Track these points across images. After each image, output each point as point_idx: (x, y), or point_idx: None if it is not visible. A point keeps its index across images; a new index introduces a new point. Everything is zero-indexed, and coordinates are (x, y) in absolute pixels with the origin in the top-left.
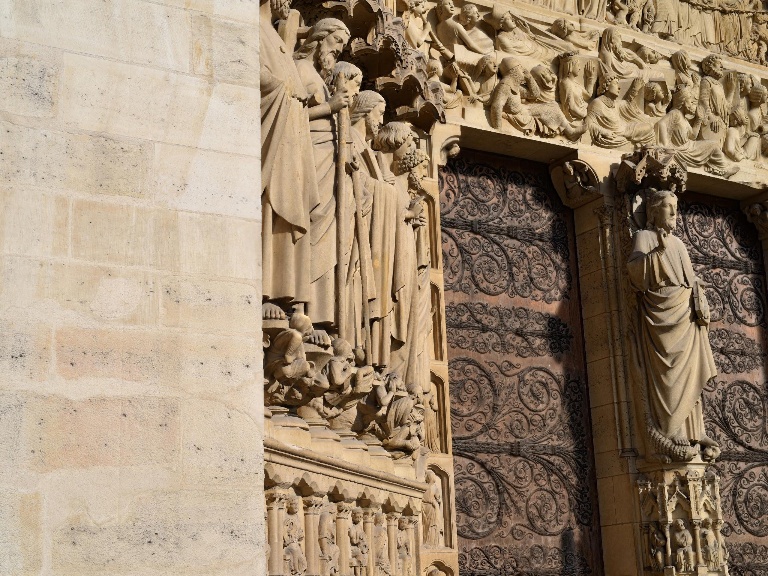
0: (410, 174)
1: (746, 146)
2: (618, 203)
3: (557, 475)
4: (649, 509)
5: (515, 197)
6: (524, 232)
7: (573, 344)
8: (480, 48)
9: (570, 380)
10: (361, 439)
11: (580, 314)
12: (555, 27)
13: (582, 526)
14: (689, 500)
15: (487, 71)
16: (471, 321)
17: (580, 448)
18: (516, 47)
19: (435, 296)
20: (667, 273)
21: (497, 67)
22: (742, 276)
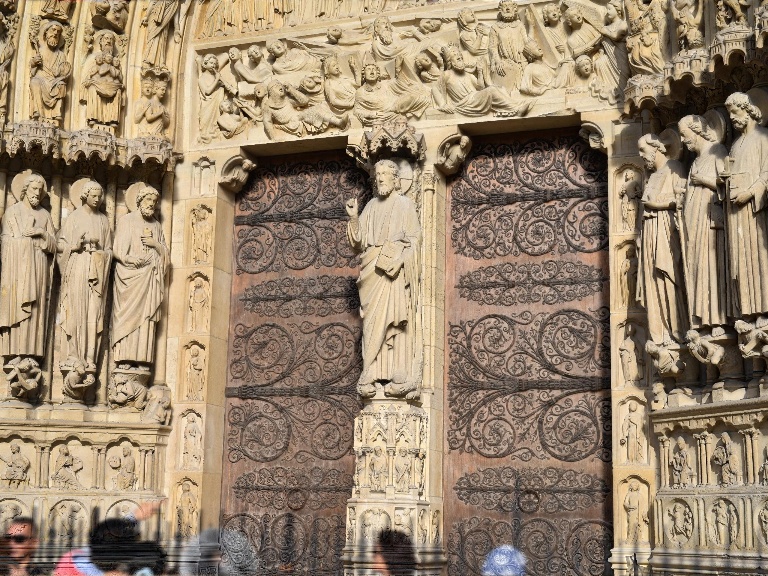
0: None
1: None
2: None
3: (343, 411)
4: None
5: (330, 183)
6: (334, 212)
7: None
8: (258, 79)
9: None
10: None
11: None
12: None
13: None
14: (362, 431)
15: None
16: (279, 293)
17: None
18: (286, 68)
19: None
20: (354, 238)
21: (267, 91)
22: (585, 203)
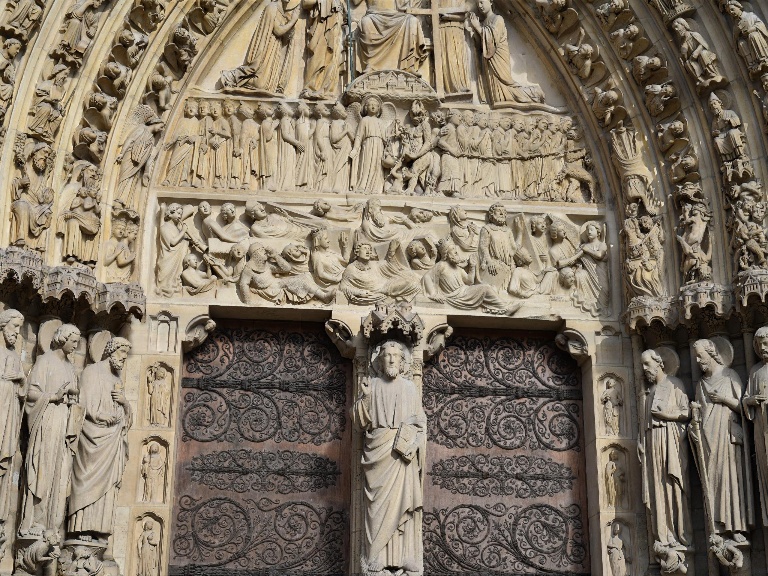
0: (110, 358)
1: (541, 282)
2: None
3: None
4: None
5: (292, 355)
6: (297, 385)
7: (340, 479)
8: (233, 238)
9: (332, 512)
10: (15, 573)
11: None
12: (313, 208)
13: None
14: None
15: (235, 257)
16: (233, 466)
17: (336, 572)
18: (268, 232)
19: (167, 450)
20: (368, 417)
21: (246, 252)
22: (554, 403)
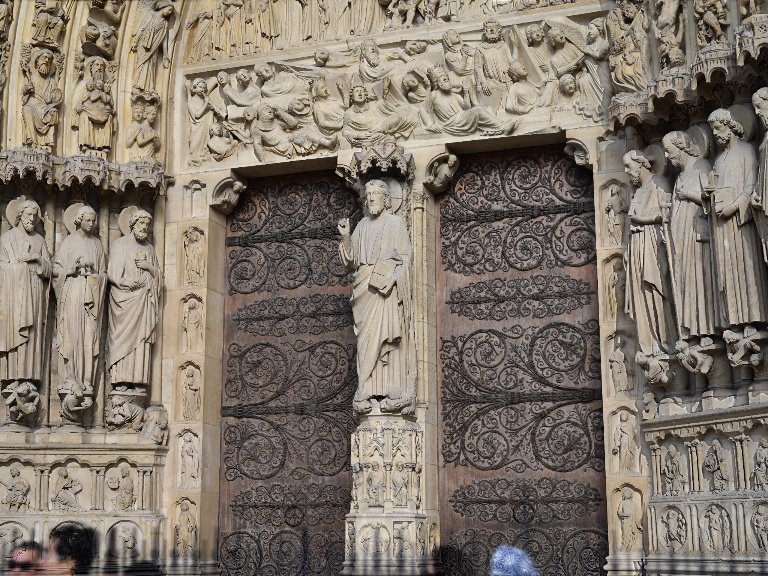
0: (133, 230)
1: None
2: None
3: (338, 427)
4: None
5: (320, 203)
6: (324, 231)
7: None
8: (247, 102)
9: None
10: None
11: None
12: None
13: None
14: (359, 447)
15: None
16: (272, 313)
17: None
18: (275, 91)
19: None
20: (347, 257)
21: None
22: (572, 218)
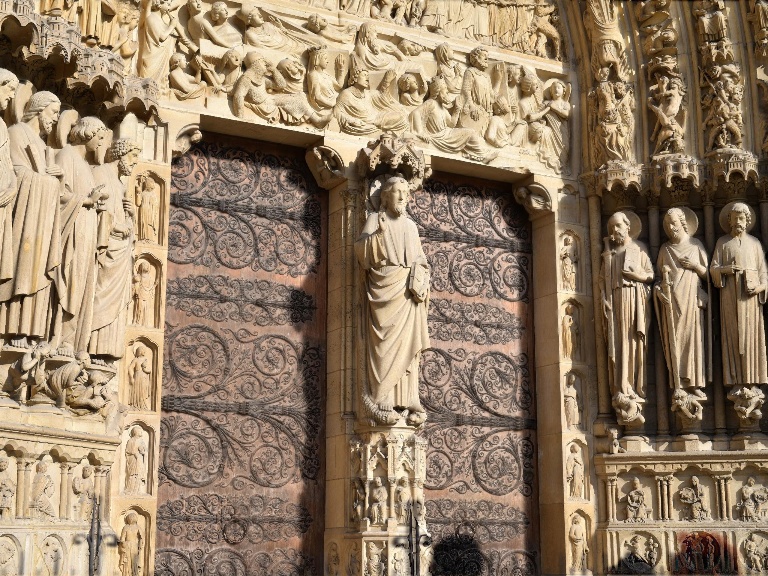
0: (120, 162)
1: (512, 133)
2: (361, 187)
3: (286, 433)
4: (357, 467)
5: (268, 179)
6: (274, 211)
7: (316, 315)
8: (226, 42)
9: (309, 347)
10: (34, 398)
11: (326, 287)
12: (308, 22)
13: (307, 480)
14: (387, 460)
15: (230, 64)
16: (210, 292)
17: (313, 409)
18: (264, 41)
19: (158, 270)
20: (384, 254)
21: (241, 60)
22: (507, 254)
